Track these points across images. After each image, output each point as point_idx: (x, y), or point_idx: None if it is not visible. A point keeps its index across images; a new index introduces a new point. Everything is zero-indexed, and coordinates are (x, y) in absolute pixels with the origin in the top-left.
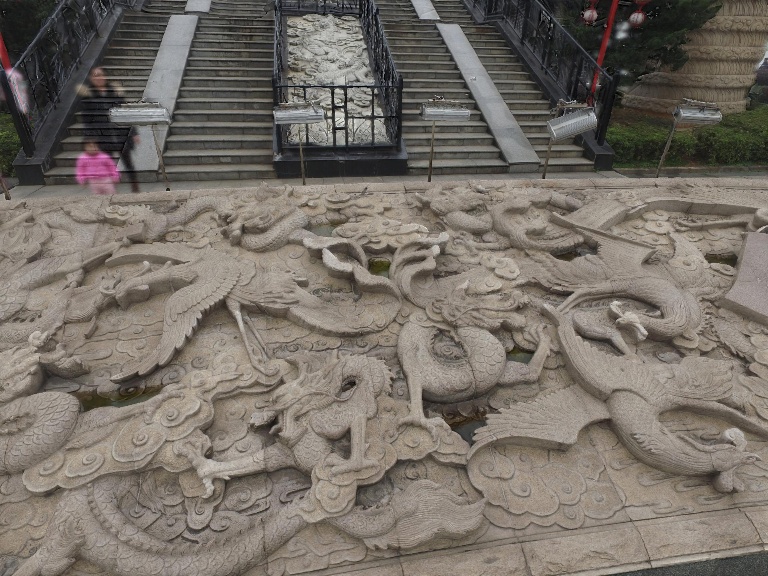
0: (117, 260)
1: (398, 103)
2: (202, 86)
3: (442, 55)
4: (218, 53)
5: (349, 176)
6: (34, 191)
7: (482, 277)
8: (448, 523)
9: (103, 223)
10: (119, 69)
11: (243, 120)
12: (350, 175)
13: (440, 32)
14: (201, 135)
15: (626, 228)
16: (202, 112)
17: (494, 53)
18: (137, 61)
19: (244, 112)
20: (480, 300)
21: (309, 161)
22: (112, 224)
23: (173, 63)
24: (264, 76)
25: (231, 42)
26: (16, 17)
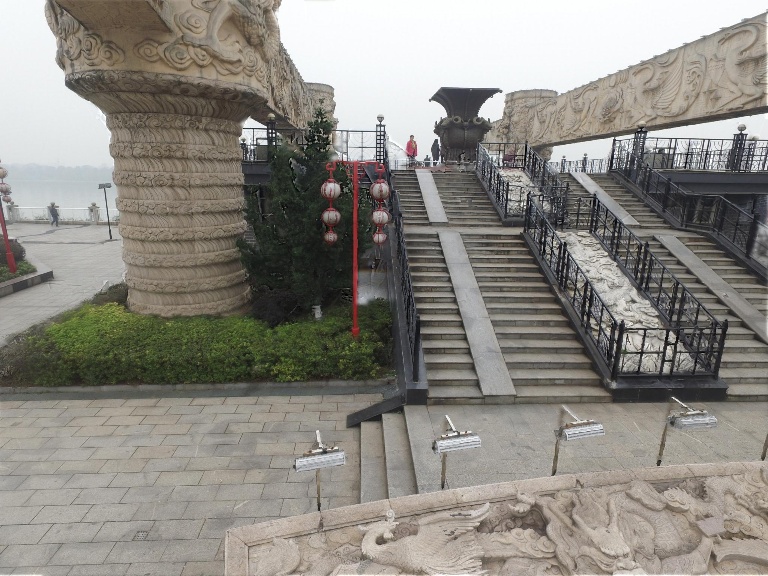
0: (722, 559)
1: (721, 341)
2: (495, 302)
3: (679, 268)
4: (492, 269)
5: (674, 401)
6: (428, 414)
7: None
8: None
9: (664, 509)
10: (426, 287)
11: (548, 338)
12: (674, 400)
13: (663, 244)
14: (523, 354)
15: None
16: (516, 332)
17: (720, 264)
18: (434, 278)
19: (550, 332)
20: None
21: (642, 389)
22: (672, 510)
23: (467, 281)
24: (539, 291)
25: (498, 258)
26: (348, 246)
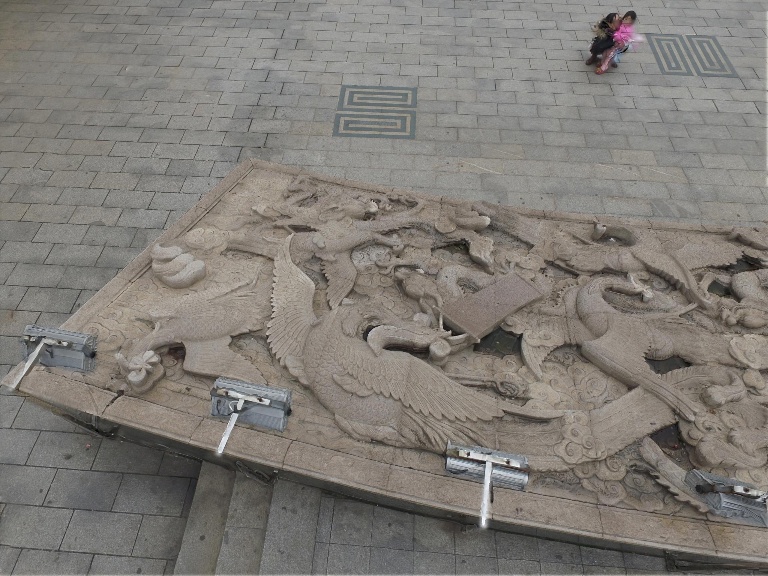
0: None
1: None
2: None
3: None
4: None
5: None
6: None
7: (764, 351)
8: (749, 231)
9: None
10: None
11: None
12: None
13: None
14: None
15: (582, 407)
16: None
17: None
18: None
19: None
20: (765, 317)
21: None
22: None
23: None
24: None
25: None
26: None
